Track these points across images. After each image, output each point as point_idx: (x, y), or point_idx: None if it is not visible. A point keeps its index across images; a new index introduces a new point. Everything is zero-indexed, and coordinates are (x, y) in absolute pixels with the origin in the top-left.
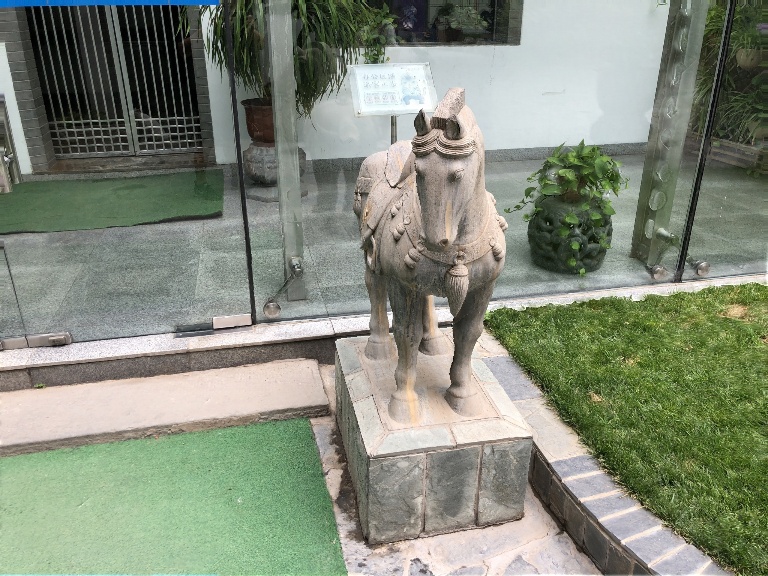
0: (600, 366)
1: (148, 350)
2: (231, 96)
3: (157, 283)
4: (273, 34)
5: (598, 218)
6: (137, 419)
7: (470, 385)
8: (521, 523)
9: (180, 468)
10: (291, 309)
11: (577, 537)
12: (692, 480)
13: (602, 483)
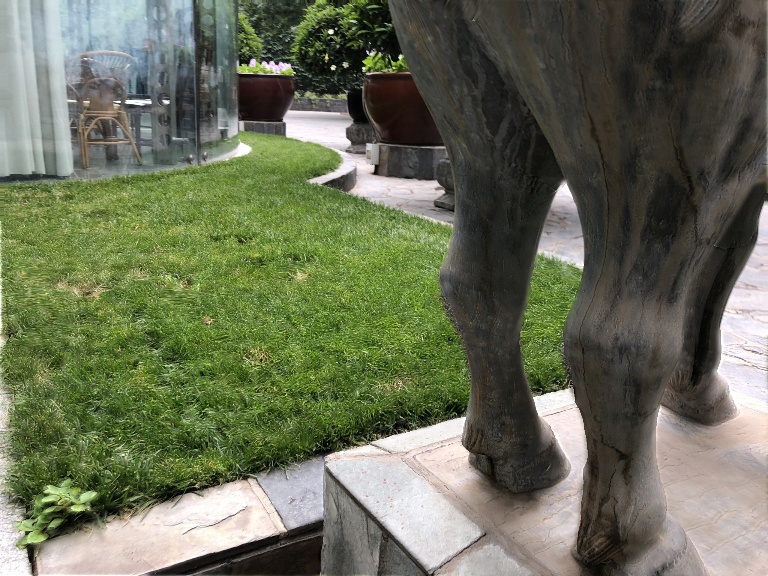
0: None
1: None
2: None
3: None
4: None
5: None
6: None
7: None
8: None
9: None
10: None
11: None
12: None
13: None
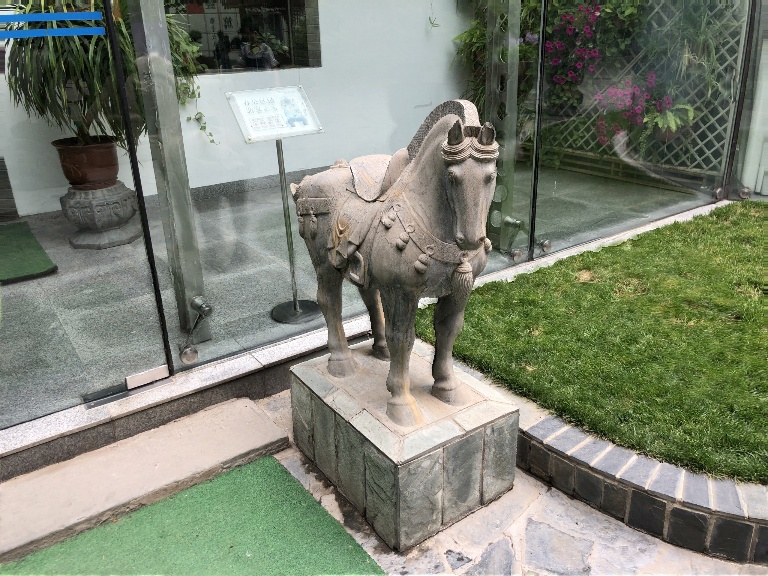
0: (516, 341)
1: (63, 429)
2: (126, 132)
3: (24, 356)
4: (152, 64)
5: None
6: (85, 507)
7: (455, 377)
8: (514, 491)
9: (162, 543)
10: (202, 352)
11: (566, 488)
12: (638, 413)
13: (575, 435)
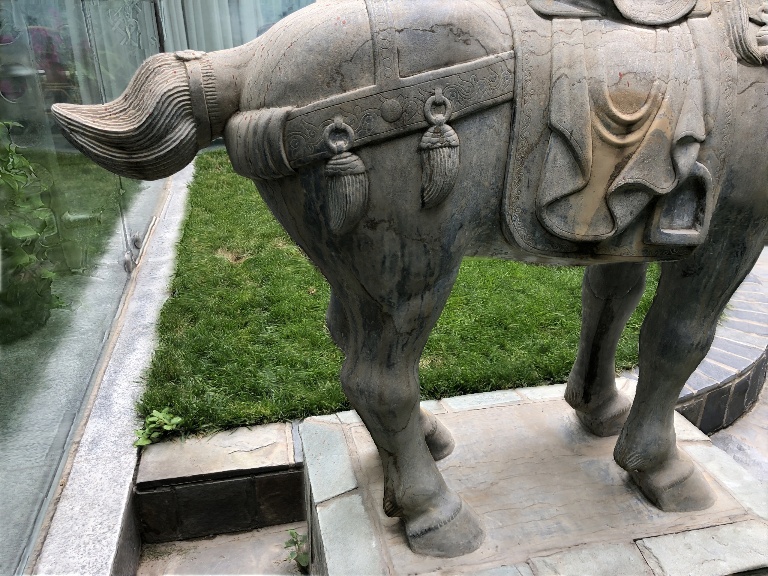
0: None
1: None
2: None
3: None
4: None
5: (48, 214)
6: None
7: None
8: None
9: None
10: None
11: None
12: None
13: None
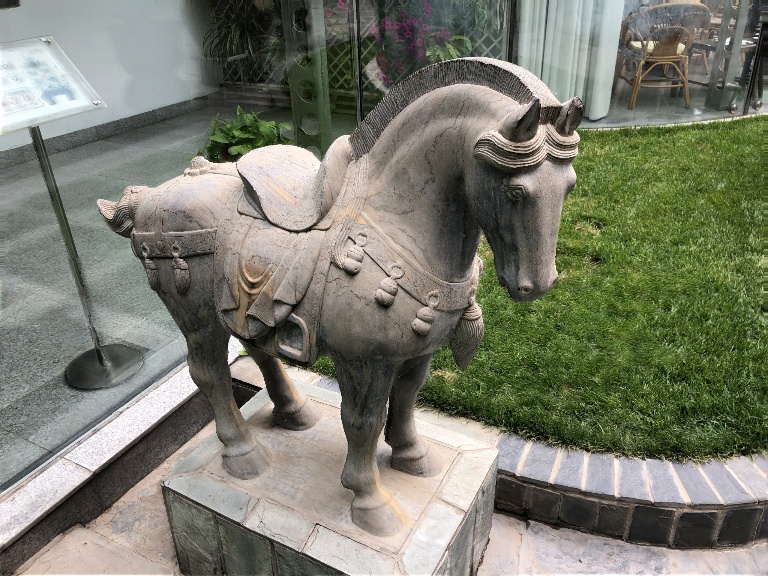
0: None
1: None
2: None
3: None
4: None
5: None
6: None
7: (420, 437)
8: (494, 542)
9: None
10: None
11: (548, 518)
12: (589, 404)
13: (543, 453)
